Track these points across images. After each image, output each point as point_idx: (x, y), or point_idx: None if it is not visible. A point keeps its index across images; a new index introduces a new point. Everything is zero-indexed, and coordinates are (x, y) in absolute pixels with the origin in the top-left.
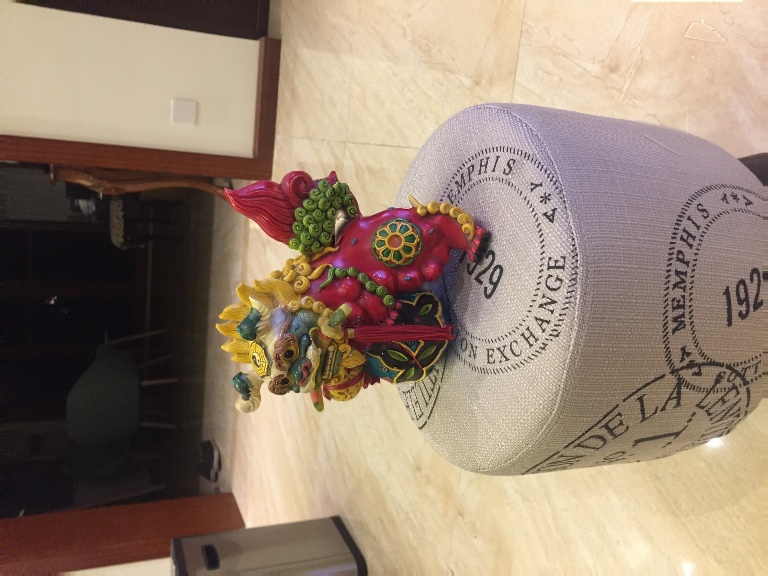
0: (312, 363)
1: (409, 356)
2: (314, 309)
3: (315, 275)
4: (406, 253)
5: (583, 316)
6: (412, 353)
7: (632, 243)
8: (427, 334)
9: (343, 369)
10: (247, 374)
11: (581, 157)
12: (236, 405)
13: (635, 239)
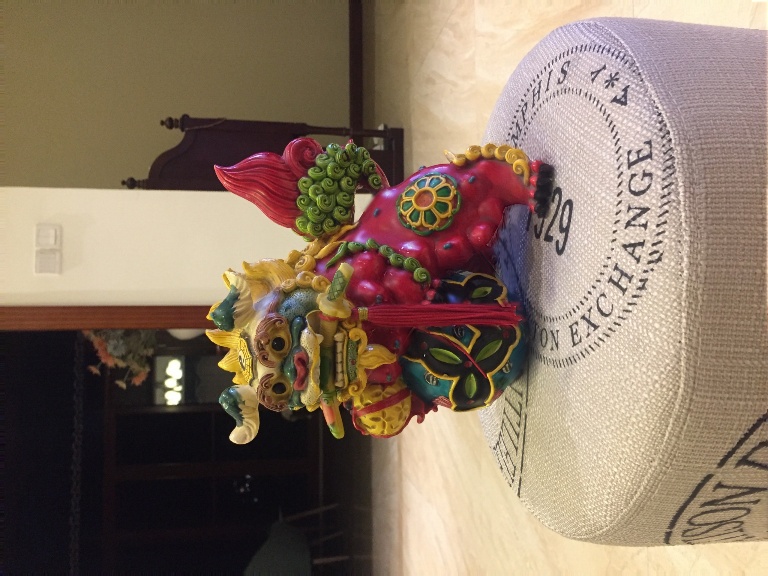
0: (308, 353)
1: (462, 355)
2: (313, 285)
3: (323, 253)
4: (441, 212)
5: (695, 218)
6: (464, 349)
7: (761, 112)
8: (478, 313)
9: (363, 371)
10: (237, 387)
11: (661, 30)
12: None
13: (766, 107)
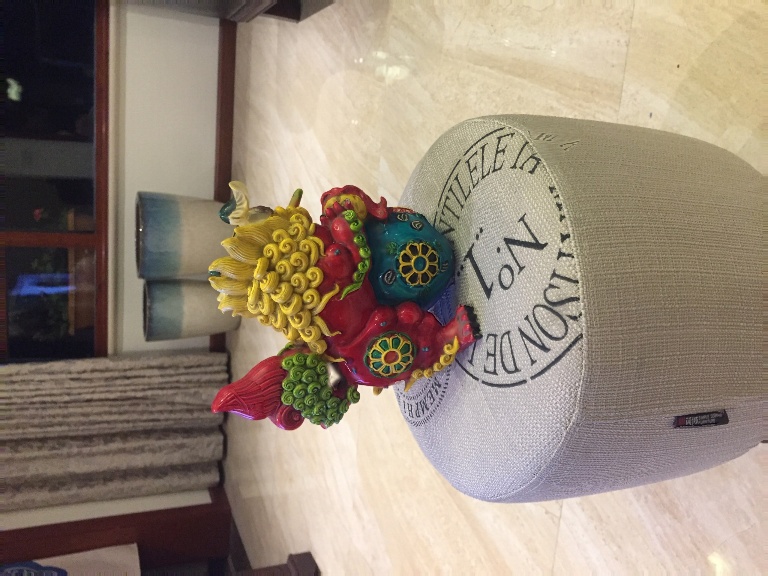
0: None
1: None
2: None
3: None
4: None
5: None
6: None
7: None
8: None
9: None
10: None
11: None
12: None
13: None
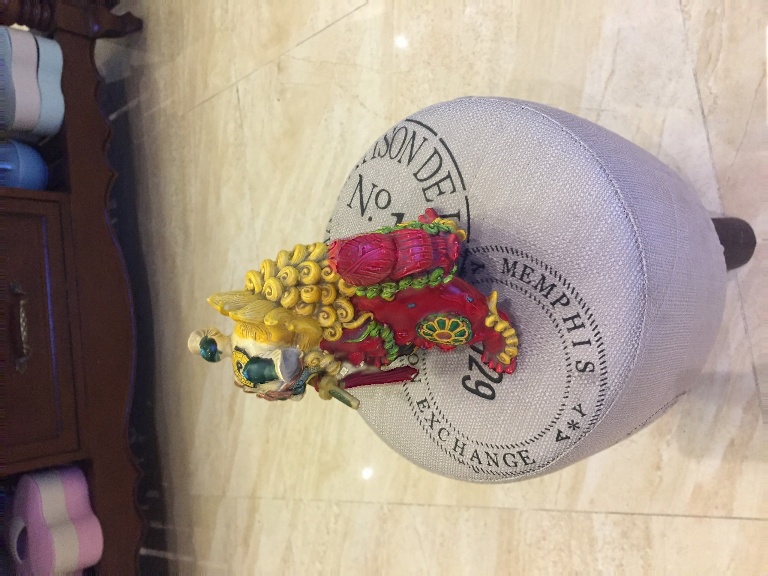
0: None
1: None
2: (327, 370)
3: (352, 327)
4: None
5: None
6: None
7: None
8: None
9: None
10: (221, 352)
11: None
12: (189, 342)
13: None
